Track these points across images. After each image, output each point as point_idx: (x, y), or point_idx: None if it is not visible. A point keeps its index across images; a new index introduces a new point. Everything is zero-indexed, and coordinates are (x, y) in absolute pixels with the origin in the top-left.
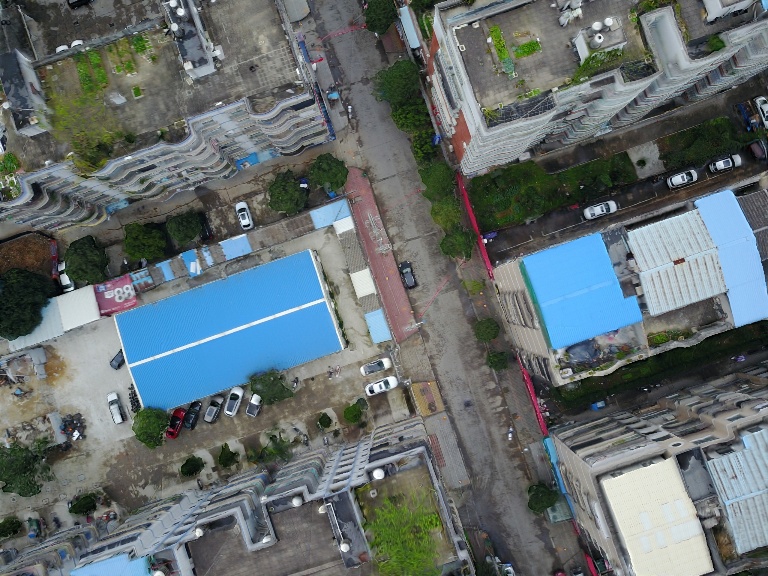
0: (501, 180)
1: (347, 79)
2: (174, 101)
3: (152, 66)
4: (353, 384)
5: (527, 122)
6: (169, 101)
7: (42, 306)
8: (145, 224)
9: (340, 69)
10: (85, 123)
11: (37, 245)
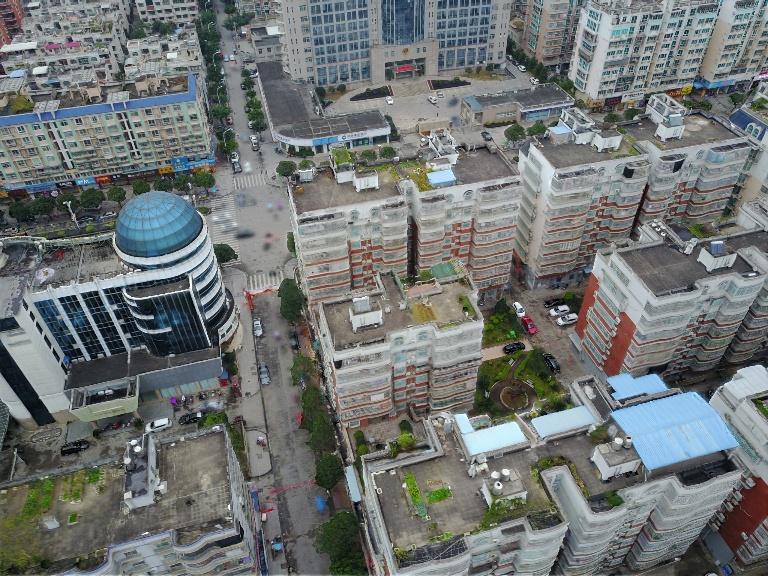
0: None
1: (294, 531)
2: (105, 529)
3: (97, 496)
4: None
5: (440, 565)
6: (100, 529)
7: None
8: None
9: (289, 521)
10: (8, 544)
11: None
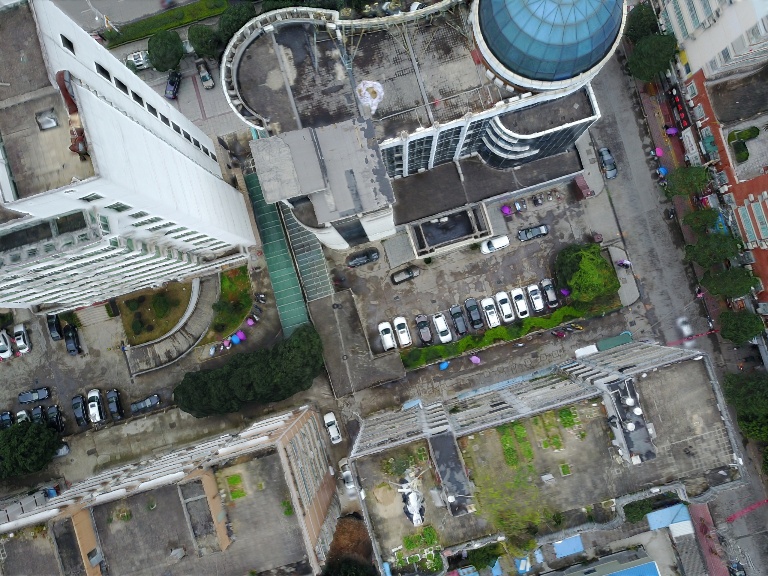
0: None
1: None
2: (602, 479)
3: (580, 442)
4: None
5: None
6: (597, 479)
7: None
8: None
9: None
10: (518, 507)
11: (352, 525)
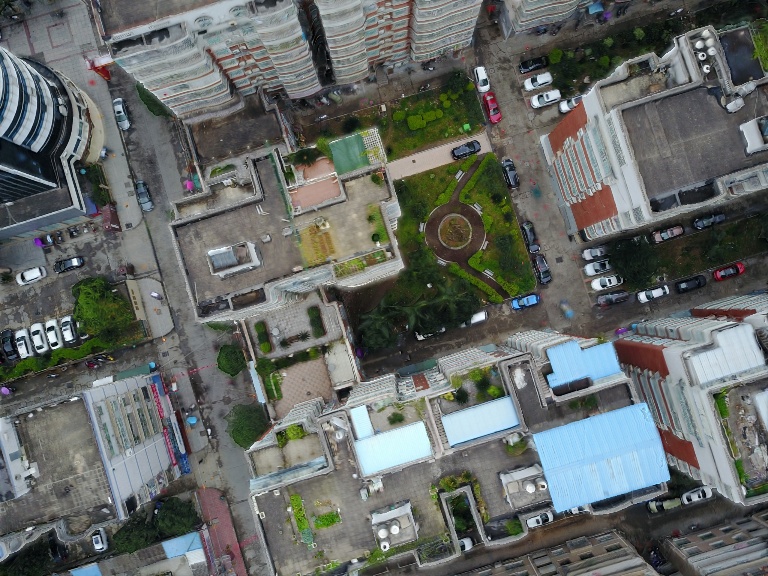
0: None
1: (209, 397)
2: None
3: None
4: None
5: None
6: None
7: None
8: None
9: (202, 387)
10: None
11: None
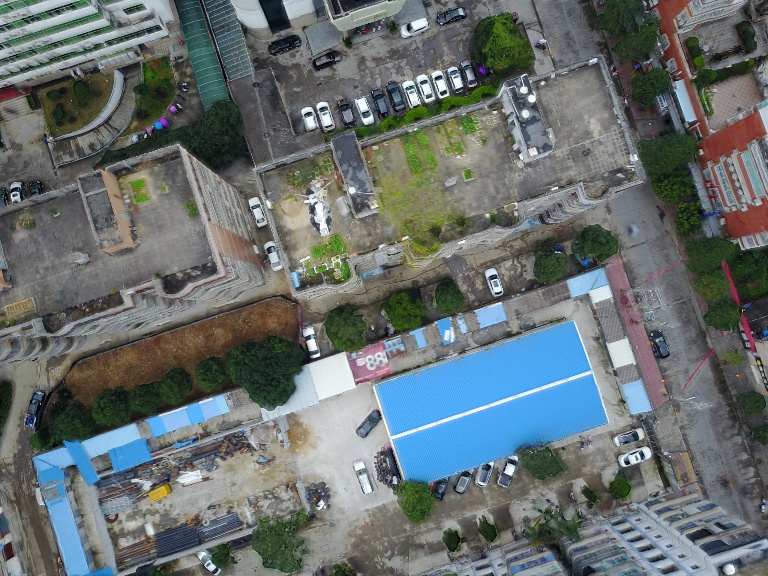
0: (759, 251)
1: None
2: (504, 184)
3: (481, 148)
4: (604, 454)
5: None
6: (499, 184)
7: (295, 374)
8: (400, 291)
9: None
10: (421, 207)
11: (279, 309)
